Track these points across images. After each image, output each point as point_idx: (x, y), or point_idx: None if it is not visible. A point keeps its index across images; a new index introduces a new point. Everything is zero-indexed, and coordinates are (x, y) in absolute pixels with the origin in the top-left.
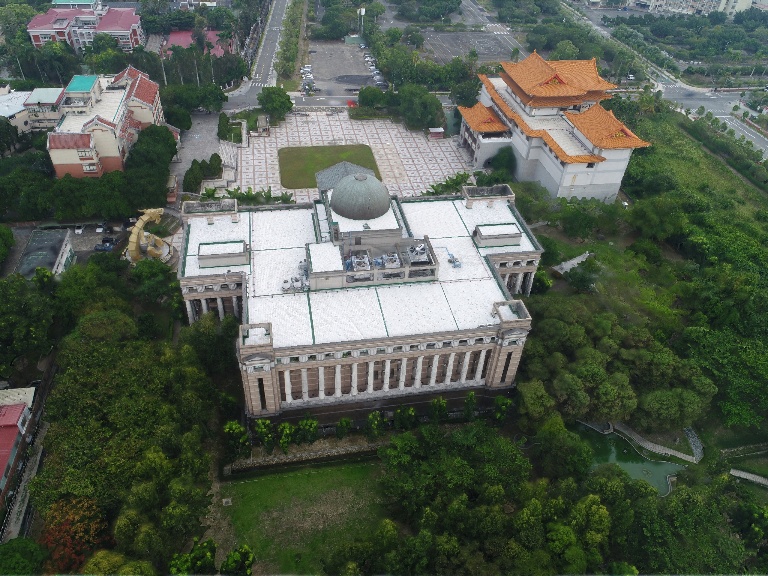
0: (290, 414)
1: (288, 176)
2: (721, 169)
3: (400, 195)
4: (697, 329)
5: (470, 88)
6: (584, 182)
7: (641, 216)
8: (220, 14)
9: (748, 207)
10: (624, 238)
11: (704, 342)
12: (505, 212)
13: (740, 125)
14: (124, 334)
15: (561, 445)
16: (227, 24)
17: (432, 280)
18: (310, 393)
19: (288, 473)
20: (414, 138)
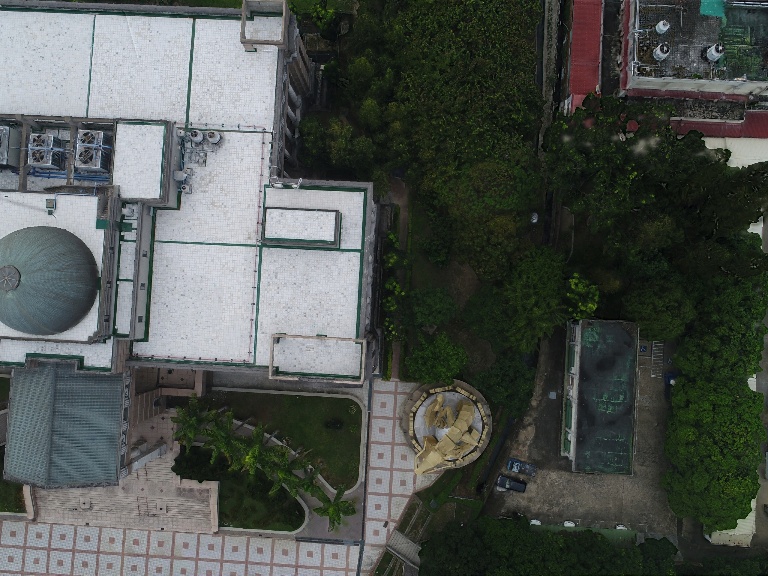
0: None
1: None
2: None
3: (2, 553)
4: None
5: None
6: None
7: None
8: None
9: None
10: None
11: None
12: None
13: None
14: None
15: None
16: None
17: None
18: None
19: None
20: None
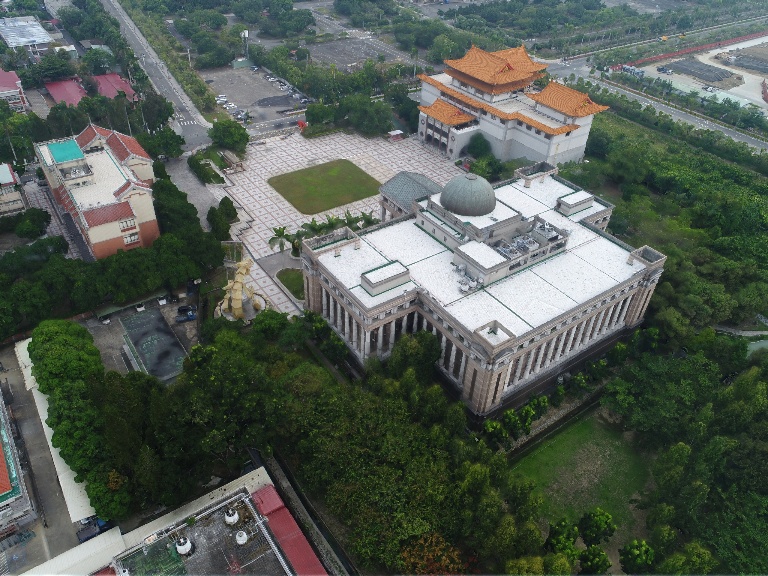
0: (503, 402)
1: (300, 203)
2: (618, 120)
3: None
4: (725, 238)
5: (402, 89)
6: (563, 149)
7: (618, 167)
8: (99, 57)
9: (658, 145)
10: (605, 188)
11: (739, 246)
12: (556, 184)
13: (602, 84)
14: (325, 383)
15: (722, 348)
16: (135, 65)
17: (563, 251)
18: (510, 378)
19: (534, 451)
20: (378, 144)
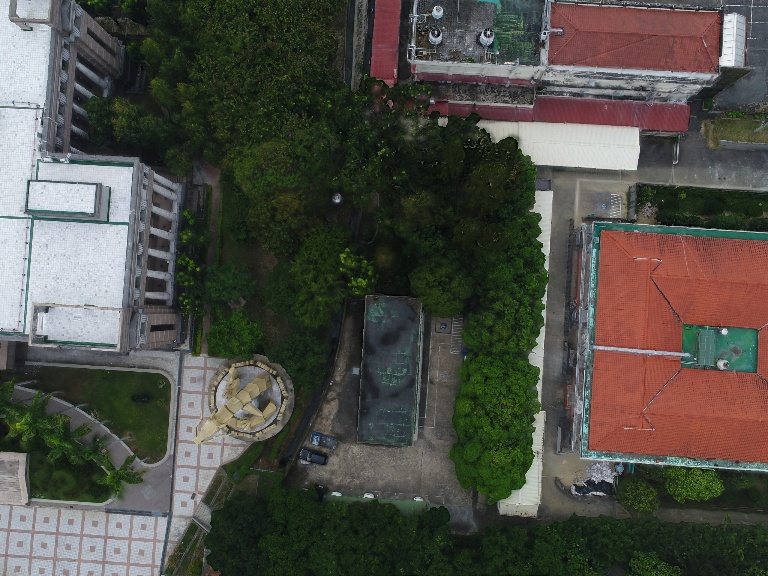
0: None
1: None
2: None
3: None
4: None
5: None
6: None
7: None
8: None
9: None
10: None
11: None
12: None
13: None
14: None
15: None
16: None
17: None
18: None
19: None
20: None
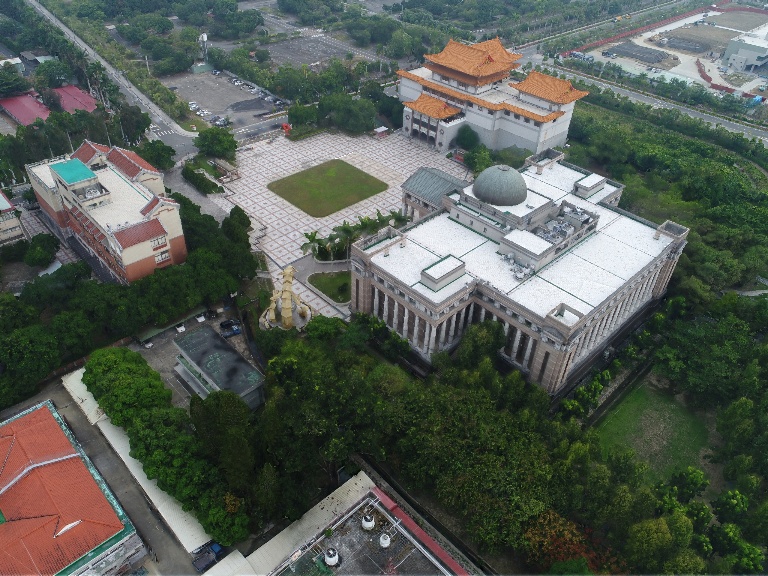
0: None
1: (308, 207)
2: (582, 105)
3: None
4: (717, 208)
5: (379, 86)
6: (550, 135)
7: (603, 149)
8: (55, 69)
9: (624, 126)
10: (590, 170)
11: (731, 214)
12: (564, 169)
13: None
14: None
15: (746, 308)
16: (104, 76)
17: (594, 232)
18: None
19: (603, 423)
20: (366, 142)
